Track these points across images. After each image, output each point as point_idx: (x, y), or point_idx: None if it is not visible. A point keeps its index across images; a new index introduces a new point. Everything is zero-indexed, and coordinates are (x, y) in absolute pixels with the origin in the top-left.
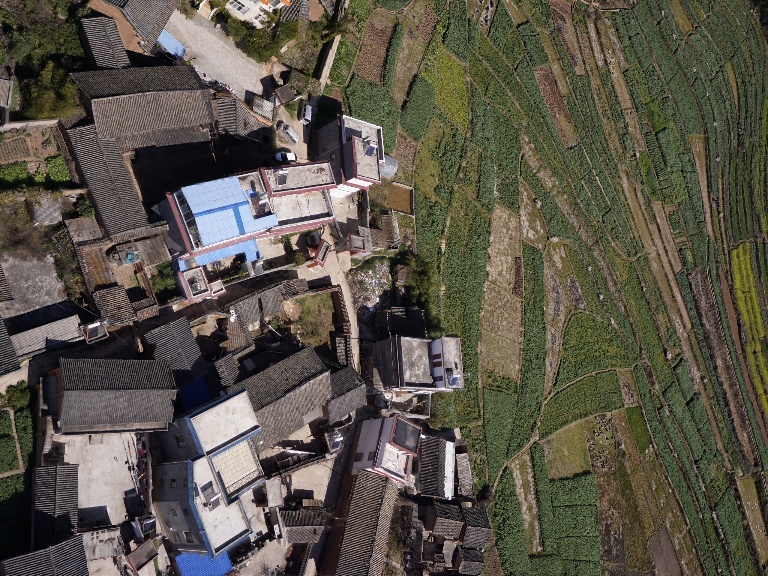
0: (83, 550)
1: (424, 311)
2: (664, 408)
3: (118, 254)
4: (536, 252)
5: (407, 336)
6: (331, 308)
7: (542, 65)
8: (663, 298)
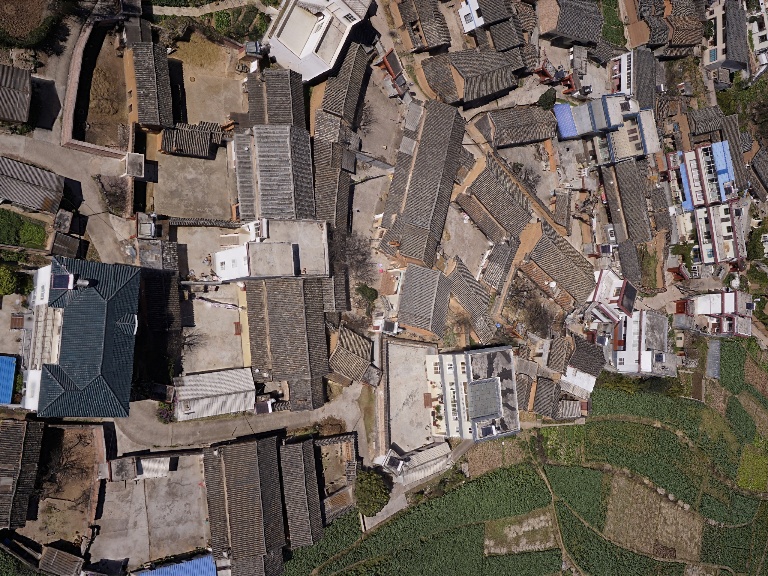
0: (594, 41)
1: None
2: None
3: (676, 122)
4: None
5: None
6: None
7: None
8: None
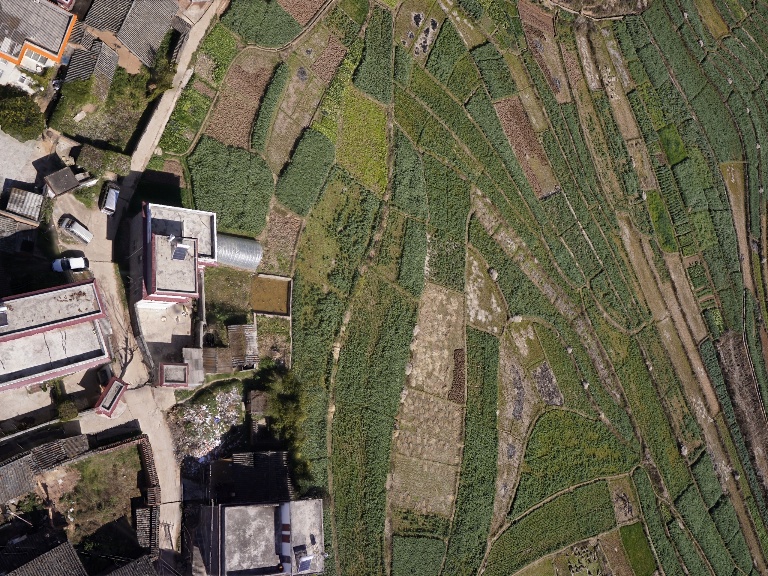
0: None
1: (288, 452)
2: (676, 521)
3: None
4: (488, 339)
5: (239, 503)
6: (136, 465)
7: (507, 96)
8: (678, 376)
